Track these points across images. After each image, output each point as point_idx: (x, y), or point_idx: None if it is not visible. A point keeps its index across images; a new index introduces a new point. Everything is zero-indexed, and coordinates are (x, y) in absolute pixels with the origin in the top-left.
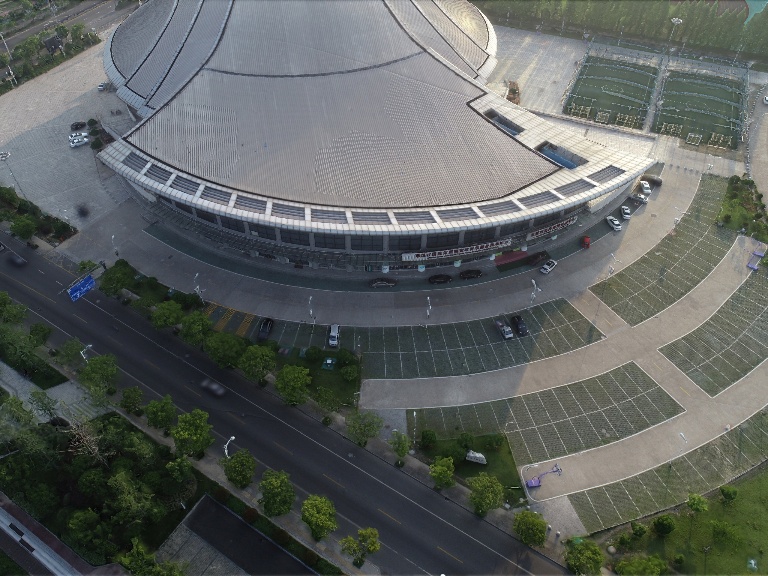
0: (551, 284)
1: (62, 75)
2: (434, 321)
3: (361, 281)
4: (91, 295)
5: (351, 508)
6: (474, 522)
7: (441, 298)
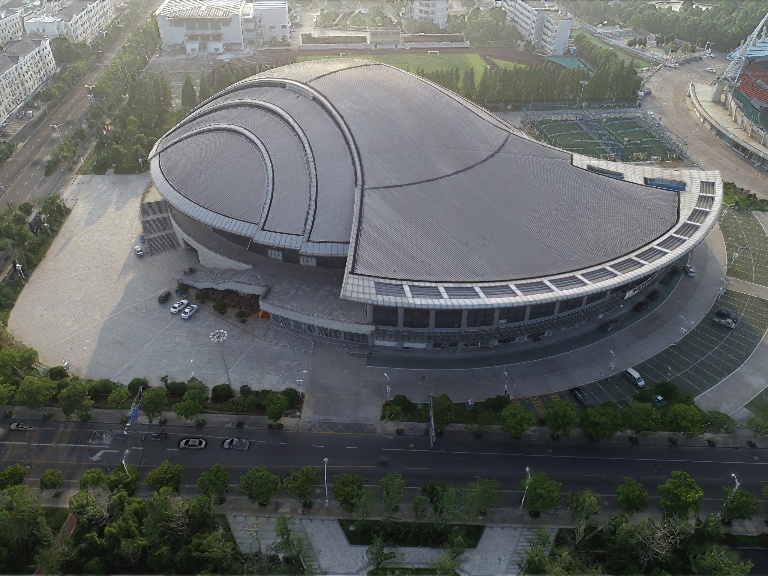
0: (705, 282)
1: (70, 254)
2: (676, 337)
3: (593, 331)
4: (397, 443)
5: None
6: None
7: (658, 320)
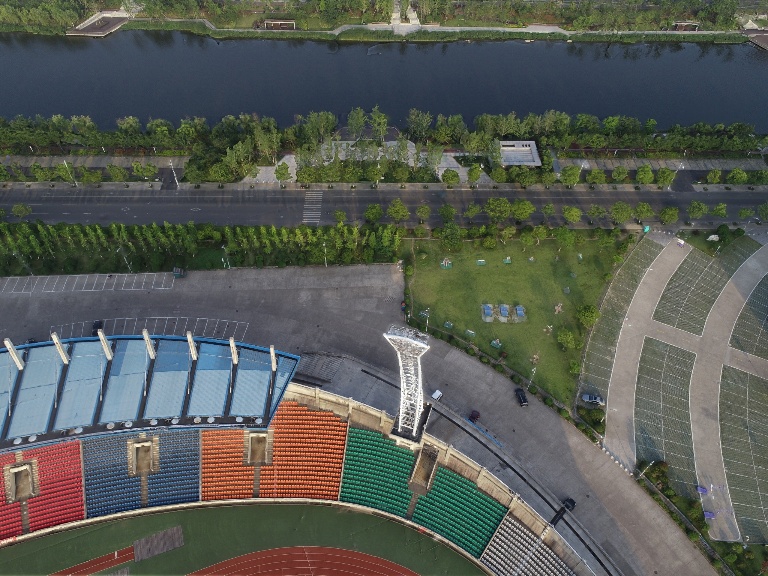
0: None
1: None
2: None
3: None
4: None
5: (730, 202)
6: (686, 220)
7: None
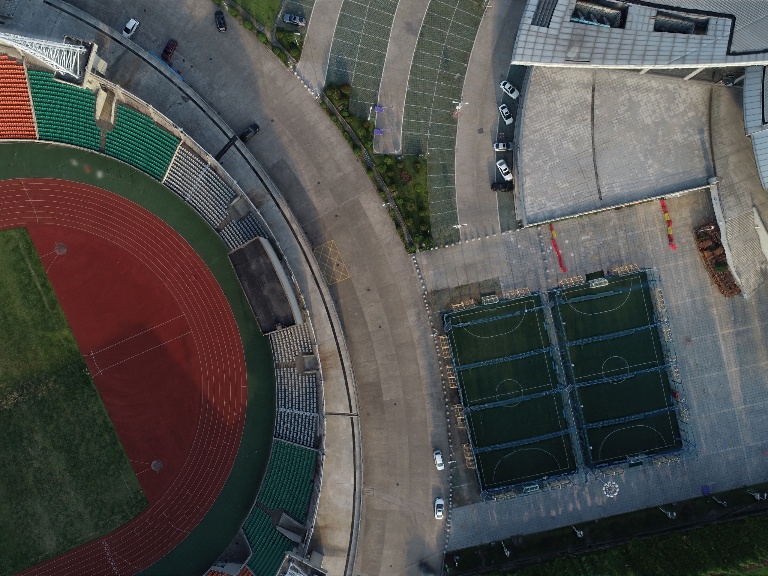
0: None
1: None
2: None
3: None
4: None
5: None
6: None
7: None
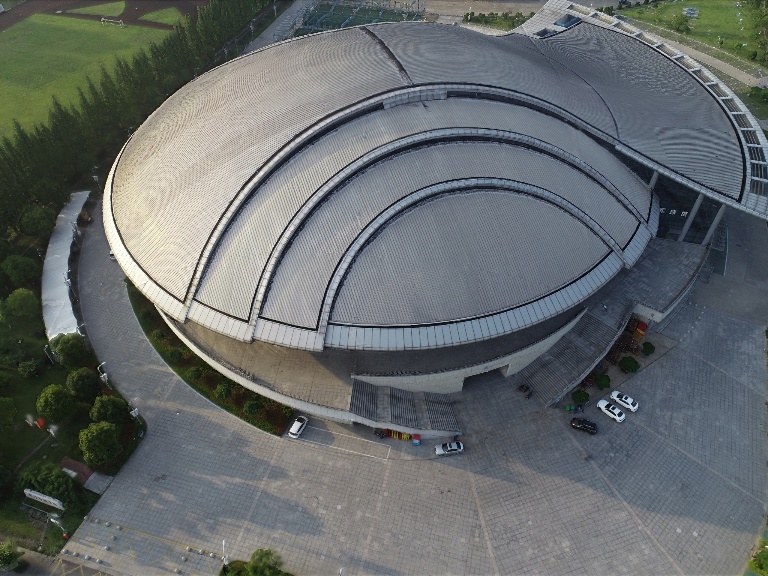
0: None
1: (418, 561)
2: None
3: None
4: None
5: None
6: None
7: None
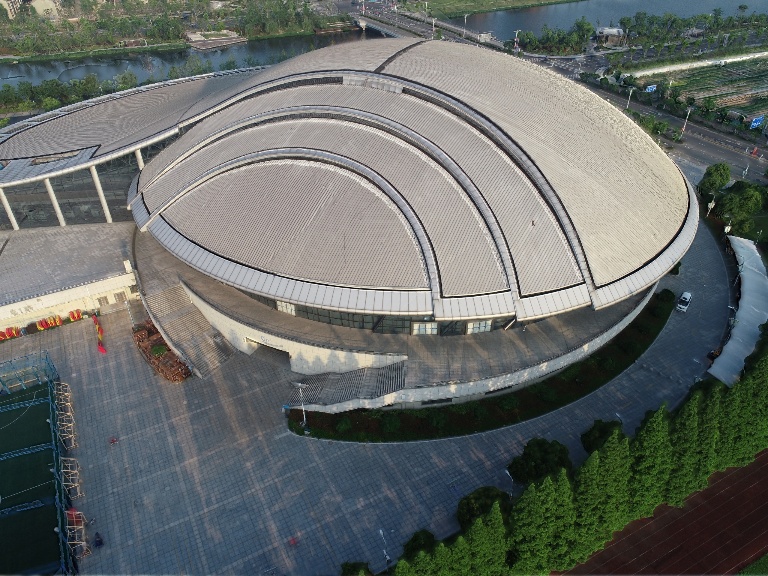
0: None
1: None
2: None
3: None
4: None
5: None
6: None
7: None
